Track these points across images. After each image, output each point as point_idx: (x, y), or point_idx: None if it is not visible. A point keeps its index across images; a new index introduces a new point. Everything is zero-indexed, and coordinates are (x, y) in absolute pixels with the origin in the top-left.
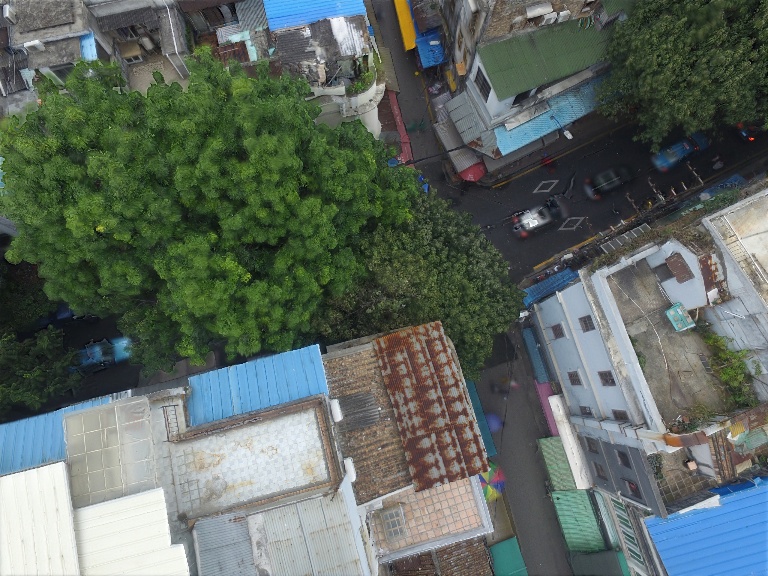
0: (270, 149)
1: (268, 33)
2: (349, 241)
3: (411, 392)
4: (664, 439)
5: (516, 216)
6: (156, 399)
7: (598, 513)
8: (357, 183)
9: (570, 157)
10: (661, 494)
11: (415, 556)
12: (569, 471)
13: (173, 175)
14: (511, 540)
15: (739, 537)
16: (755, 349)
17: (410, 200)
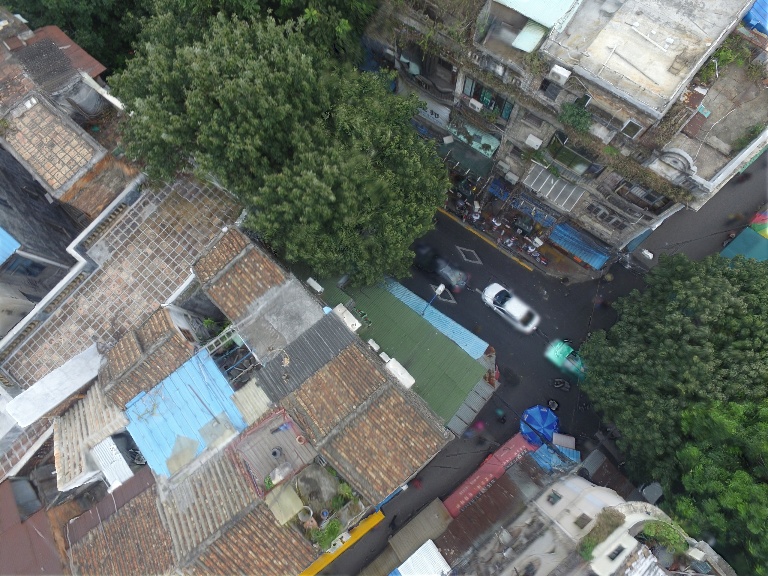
0: None
1: None
2: None
3: None
4: None
5: (502, 308)
6: None
7: None
8: None
9: None
10: None
11: None
12: None
13: None
14: None
15: None
16: None
17: None
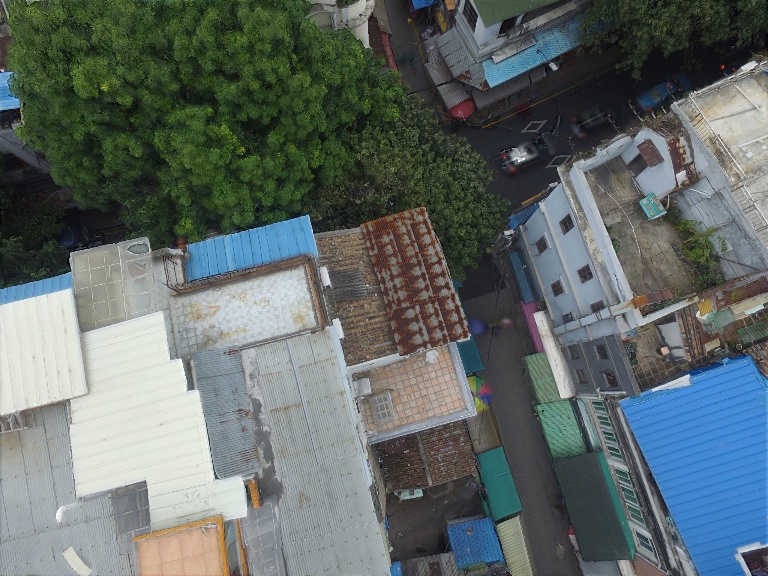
0: (262, 20)
1: None
2: (339, 138)
3: (397, 269)
4: (633, 303)
5: (505, 152)
6: (156, 253)
7: (580, 420)
8: (345, 68)
9: (558, 99)
10: (636, 379)
11: (403, 441)
12: (553, 384)
13: (172, 50)
14: (498, 450)
15: (708, 413)
16: (721, 227)
17: (398, 108)
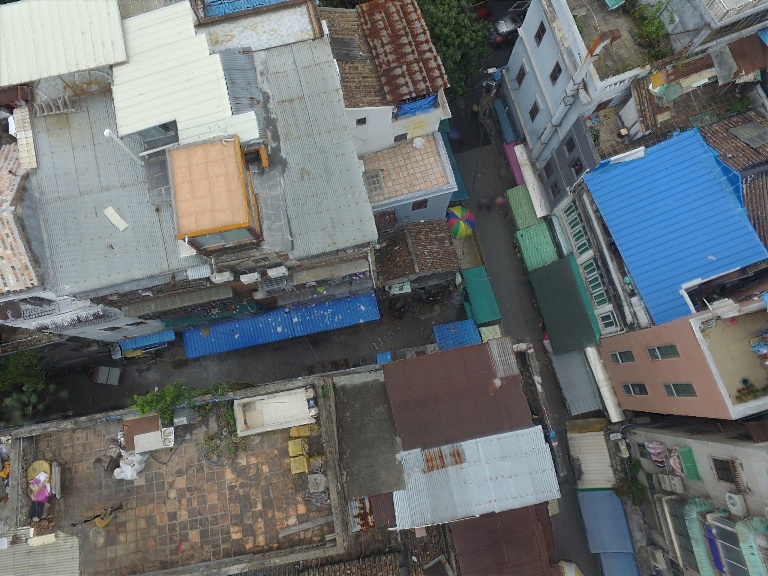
0: None
1: None
2: None
3: (387, 39)
4: (589, 52)
5: (492, 23)
6: None
7: (554, 234)
8: None
9: None
10: None
11: (392, 216)
12: (531, 210)
13: None
14: (480, 268)
15: (660, 177)
16: (669, 1)
17: None
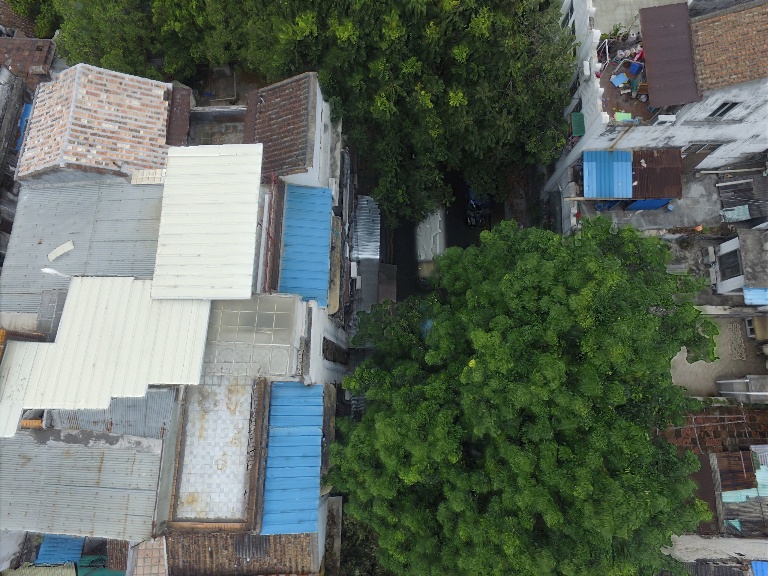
0: None
1: (766, 523)
2: None
3: None
4: None
5: None
6: None
7: None
8: None
9: None
10: None
11: None
12: None
13: None
14: None
15: None
16: None
17: None
